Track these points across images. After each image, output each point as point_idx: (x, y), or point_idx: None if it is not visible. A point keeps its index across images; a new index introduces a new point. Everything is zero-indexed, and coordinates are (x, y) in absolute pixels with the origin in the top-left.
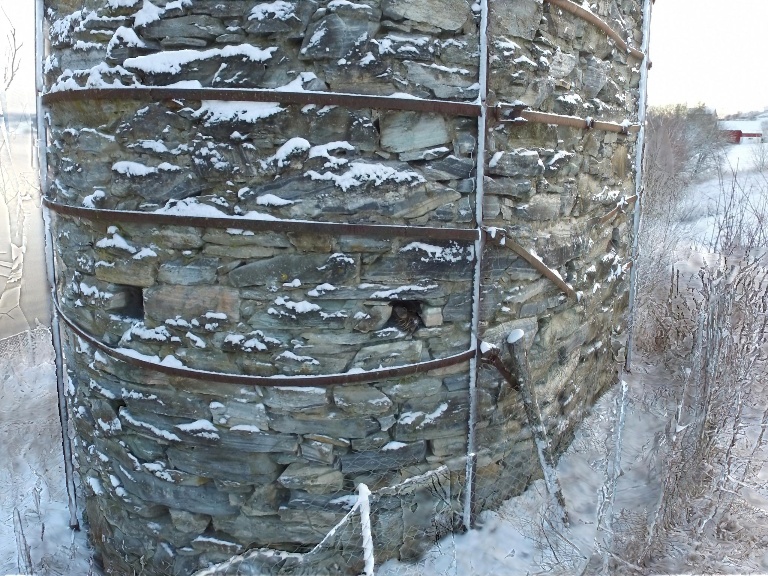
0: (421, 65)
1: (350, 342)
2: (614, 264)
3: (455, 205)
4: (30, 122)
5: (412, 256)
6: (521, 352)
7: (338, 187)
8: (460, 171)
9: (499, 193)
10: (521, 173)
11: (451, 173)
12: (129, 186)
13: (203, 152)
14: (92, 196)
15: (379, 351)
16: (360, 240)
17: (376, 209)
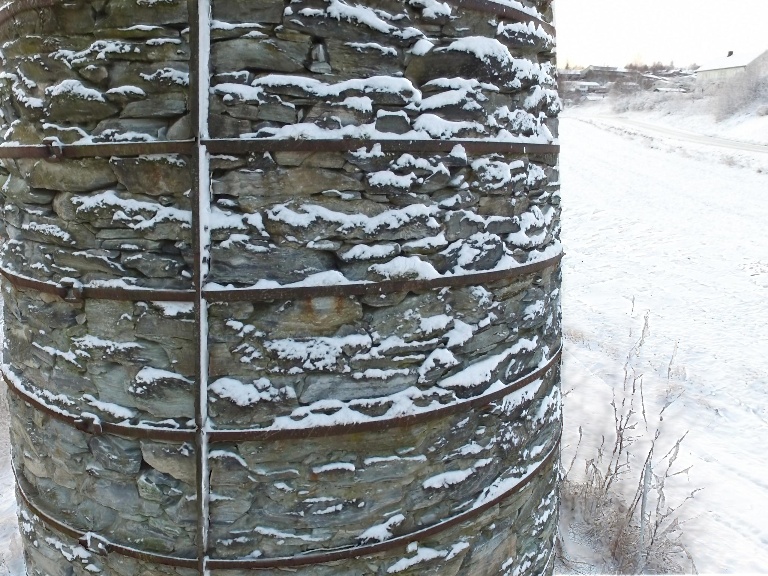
0: None
1: None
2: None
3: None
4: None
5: None
6: None
7: None
8: None
9: None
10: None
11: None
12: (446, 496)
13: (508, 437)
14: (387, 525)
15: None
16: None
17: None
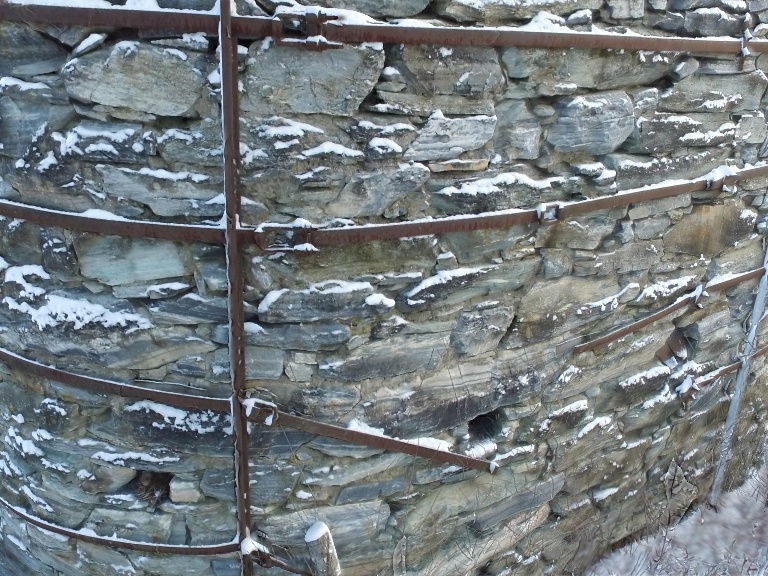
0: (122, 171)
1: (79, 499)
2: (674, 377)
3: (206, 358)
4: None
5: (140, 418)
6: (318, 556)
7: (35, 323)
8: (210, 314)
9: (279, 347)
10: (328, 317)
11: (197, 316)
12: None
13: None
14: None
15: (113, 517)
16: (71, 389)
17: (85, 356)
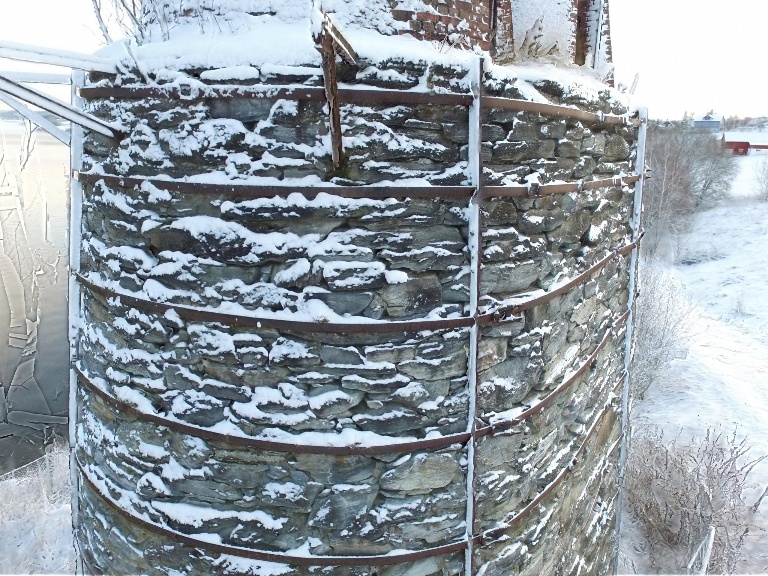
0: (414, 524)
1: None
2: None
3: None
4: (44, 199)
5: None
6: None
7: None
8: None
9: None
10: (505, 569)
11: None
12: None
13: None
14: None
15: None
16: None
17: None
